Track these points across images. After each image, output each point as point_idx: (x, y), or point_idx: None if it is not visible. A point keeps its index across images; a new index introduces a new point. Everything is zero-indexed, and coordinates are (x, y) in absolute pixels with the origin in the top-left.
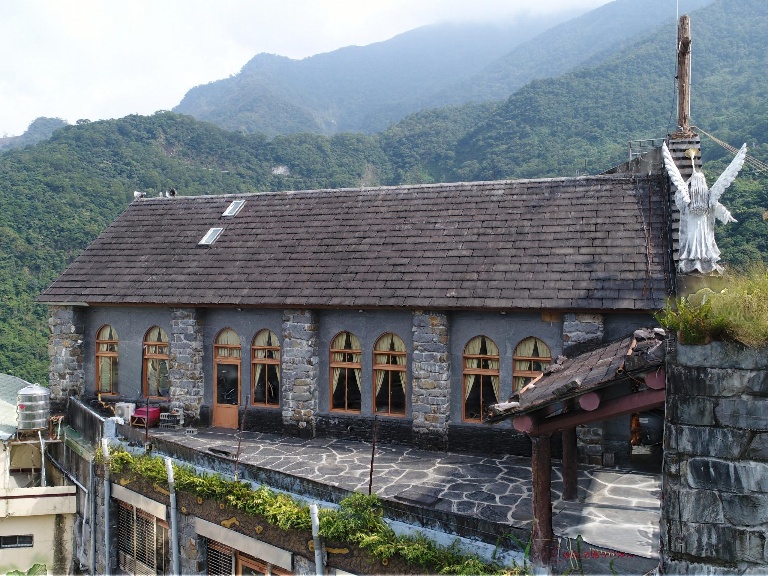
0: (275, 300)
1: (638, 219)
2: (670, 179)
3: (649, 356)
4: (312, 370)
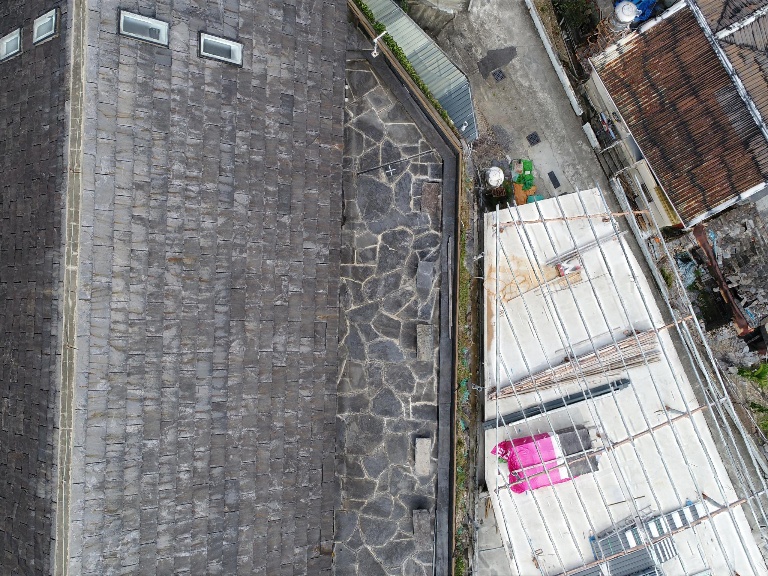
0: None
1: None
2: None
3: None
4: None
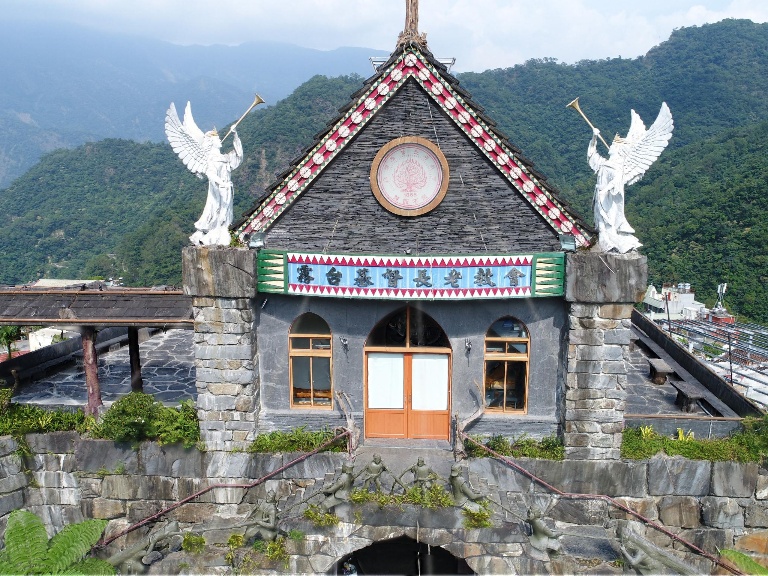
0: None
1: None
2: None
3: None
4: None
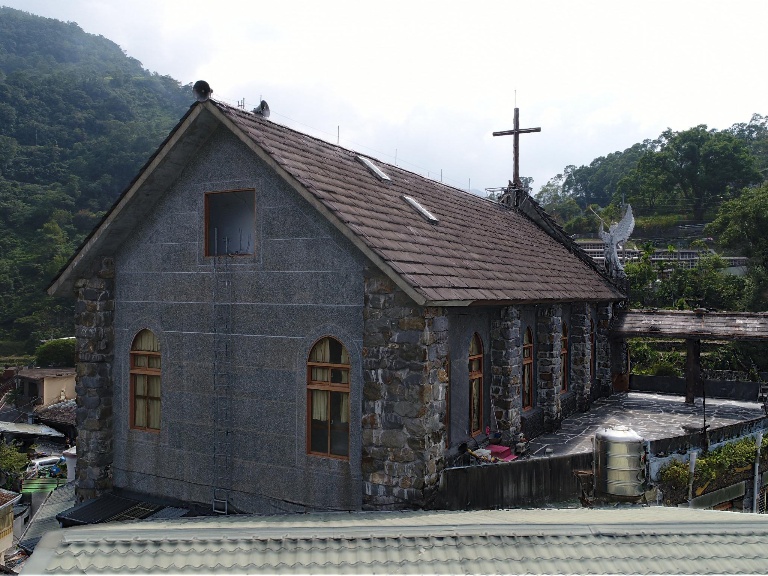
0: None
1: (554, 241)
2: (547, 216)
3: None
4: None
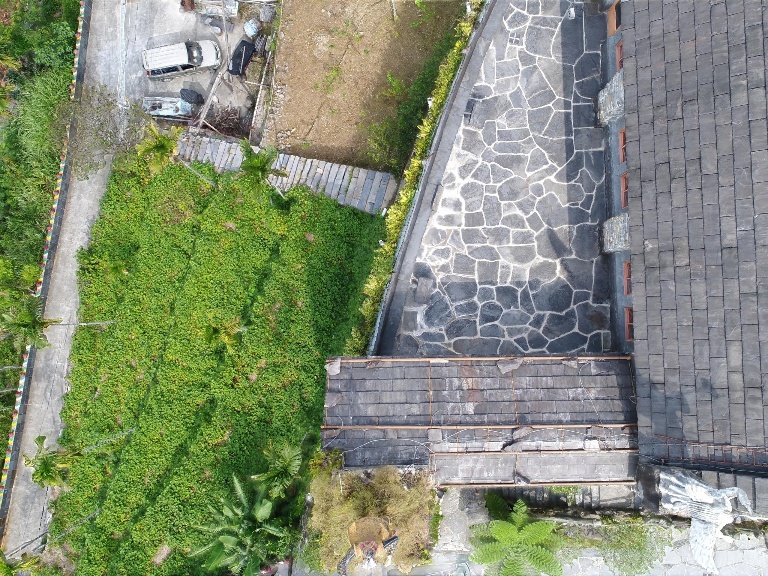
0: (628, 46)
1: None
2: None
3: (330, 441)
4: (619, 107)
